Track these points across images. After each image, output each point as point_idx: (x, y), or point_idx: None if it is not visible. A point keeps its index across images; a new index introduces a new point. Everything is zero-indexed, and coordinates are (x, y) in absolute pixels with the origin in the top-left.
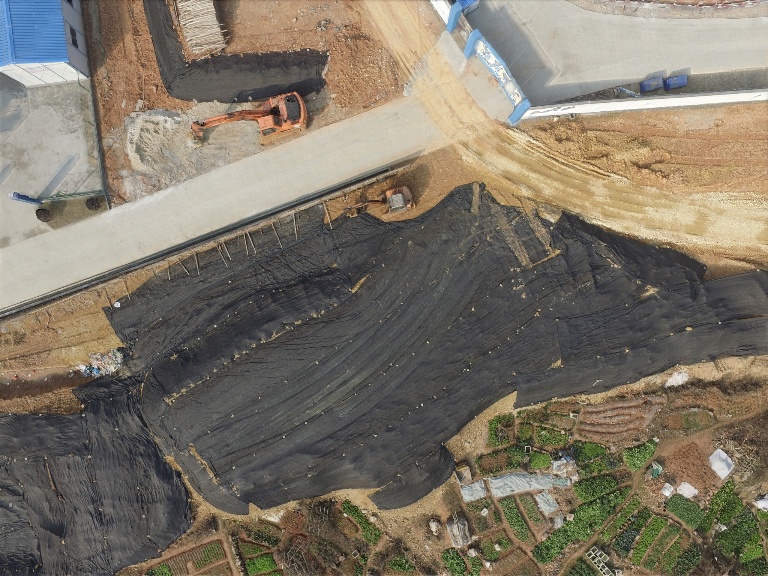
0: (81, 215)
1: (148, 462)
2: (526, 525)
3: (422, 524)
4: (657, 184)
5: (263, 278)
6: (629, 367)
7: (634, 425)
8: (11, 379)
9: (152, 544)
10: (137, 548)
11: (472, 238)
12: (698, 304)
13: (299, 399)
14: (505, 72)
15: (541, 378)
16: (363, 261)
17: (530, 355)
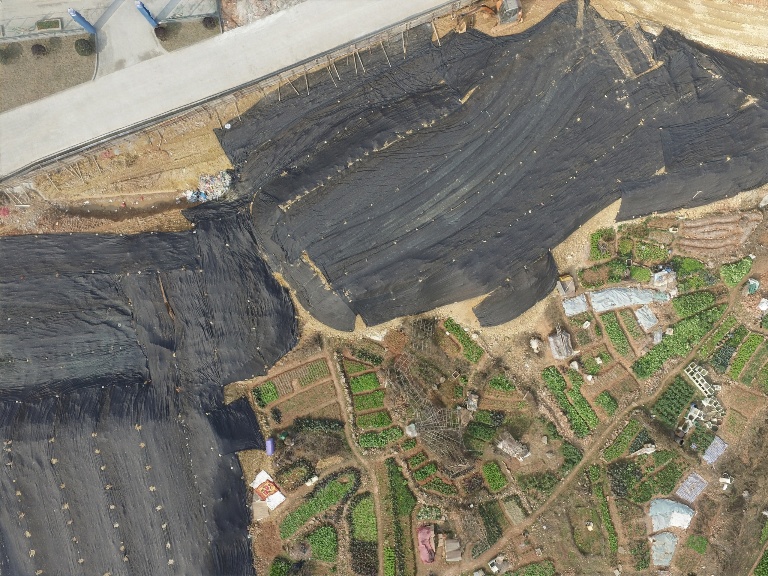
0: (195, 38)
1: (258, 276)
2: (626, 339)
3: (523, 342)
4: (754, 2)
5: (371, 97)
6: (730, 176)
7: (731, 241)
8: (119, 206)
9: (260, 358)
10: (247, 360)
11: (577, 51)
12: None
13: (410, 206)
14: None
15: (646, 185)
16: (471, 75)
17: (635, 163)
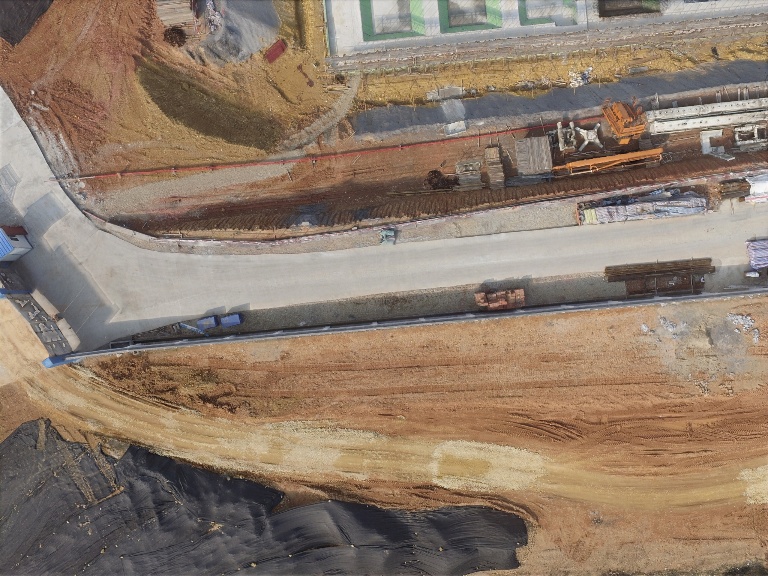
0: None
1: None
2: None
3: None
4: (227, 415)
5: None
6: None
7: None
8: None
9: None
10: None
11: (39, 474)
12: (264, 539)
13: None
14: (37, 325)
15: None
16: None
17: None
